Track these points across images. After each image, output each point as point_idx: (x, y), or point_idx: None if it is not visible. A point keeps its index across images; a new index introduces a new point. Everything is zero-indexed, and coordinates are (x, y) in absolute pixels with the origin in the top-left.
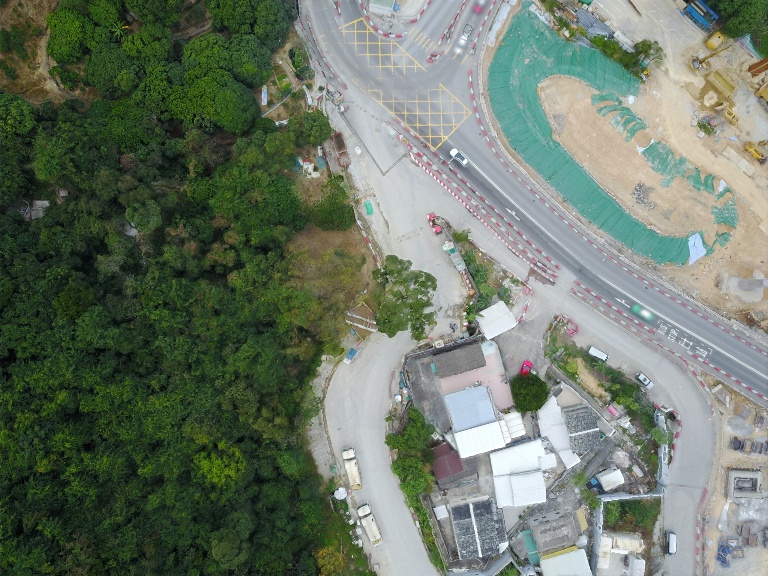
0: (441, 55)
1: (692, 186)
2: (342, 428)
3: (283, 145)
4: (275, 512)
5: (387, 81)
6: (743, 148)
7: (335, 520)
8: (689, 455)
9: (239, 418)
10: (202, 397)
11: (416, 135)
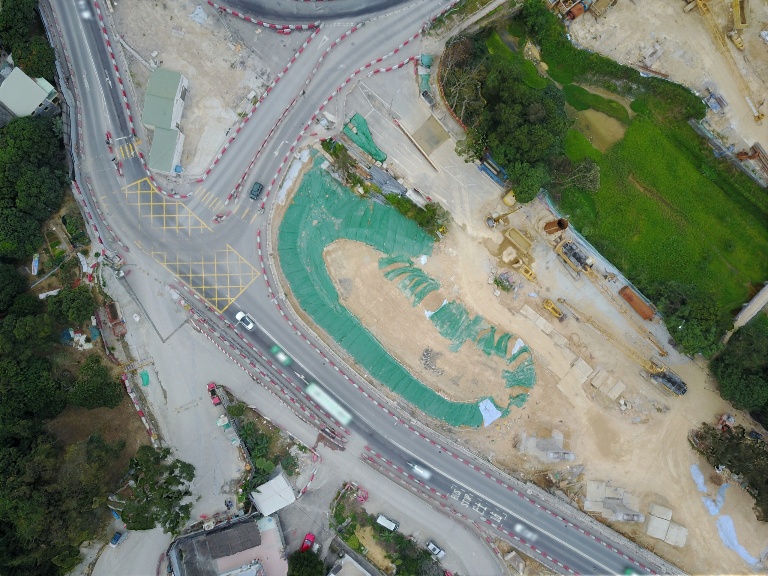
0: (228, 215)
1: (482, 351)
2: None
3: (36, 329)
4: None
5: (171, 242)
6: (542, 305)
7: None
8: None
9: None
10: None
11: (201, 298)
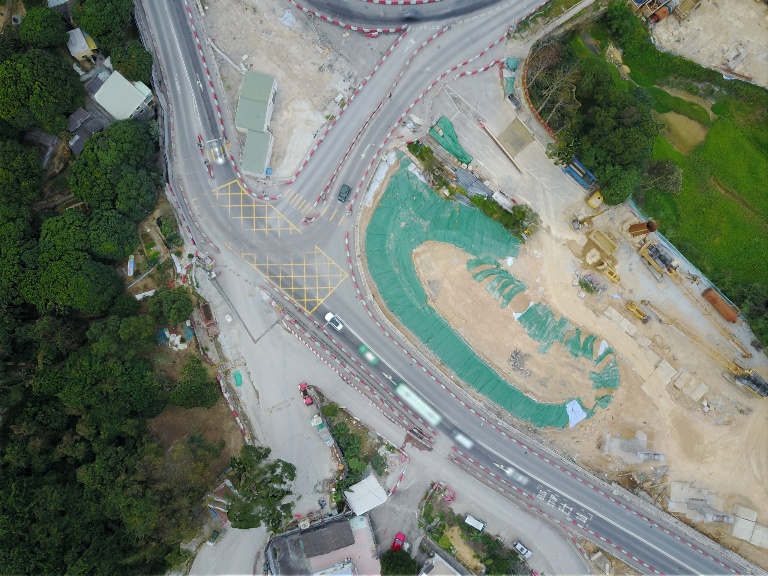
0: (317, 217)
1: (569, 352)
2: None
3: (139, 330)
4: None
5: (261, 244)
6: (625, 307)
7: None
8: None
9: None
10: None
11: (290, 299)
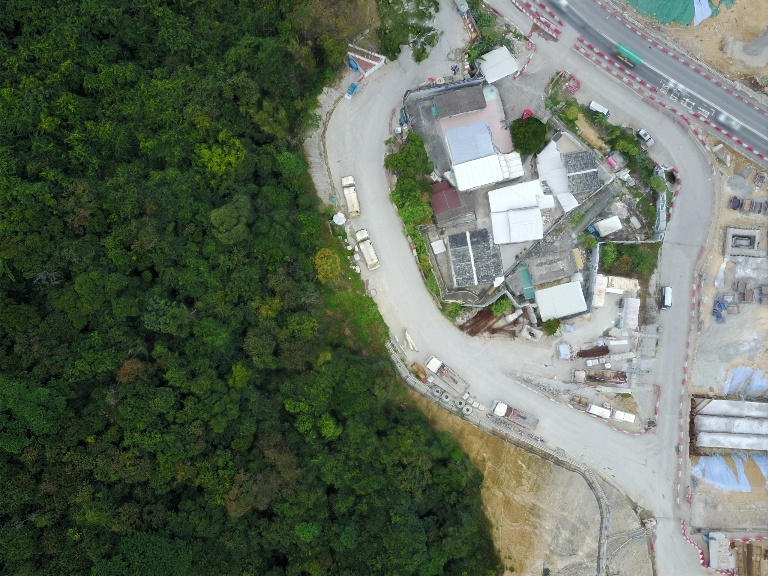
0: None
1: None
2: (342, 160)
3: None
4: (274, 211)
5: None
6: None
7: (333, 241)
8: (688, 214)
9: (240, 109)
10: (203, 82)
11: None
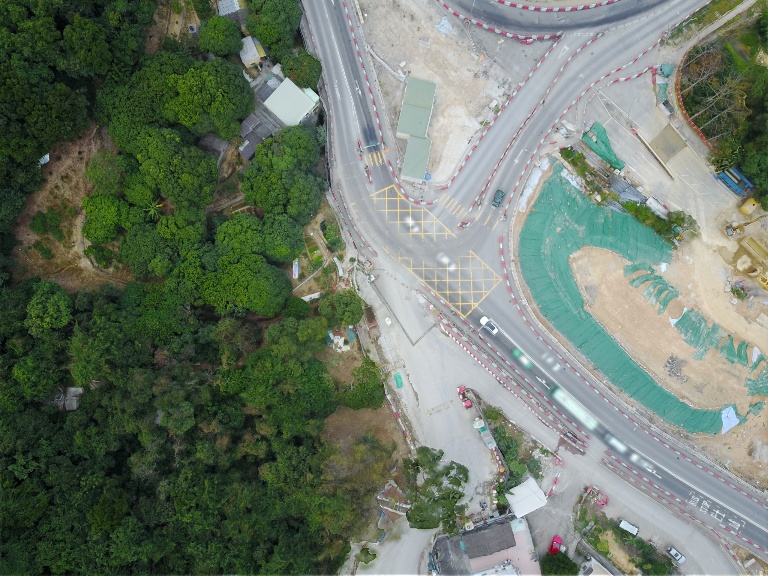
0: (472, 222)
1: (726, 359)
2: None
3: (315, 332)
4: None
5: (417, 248)
6: None
7: None
8: None
9: None
10: None
11: (446, 303)
